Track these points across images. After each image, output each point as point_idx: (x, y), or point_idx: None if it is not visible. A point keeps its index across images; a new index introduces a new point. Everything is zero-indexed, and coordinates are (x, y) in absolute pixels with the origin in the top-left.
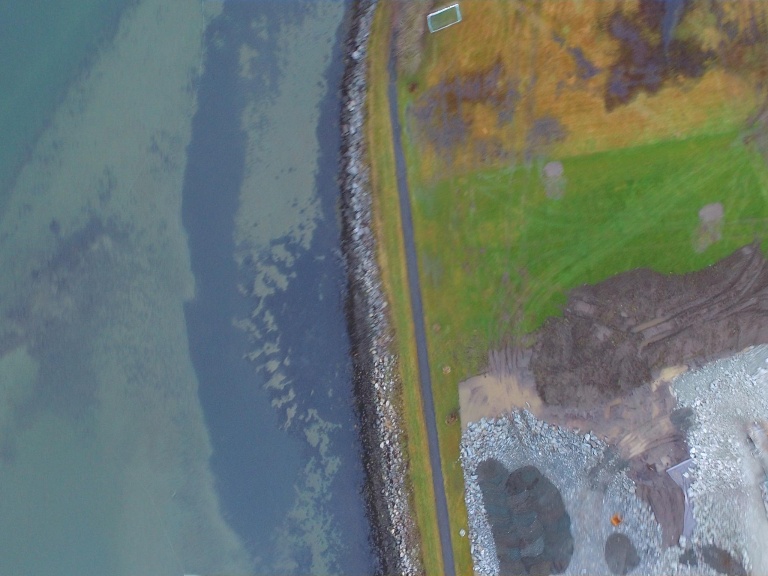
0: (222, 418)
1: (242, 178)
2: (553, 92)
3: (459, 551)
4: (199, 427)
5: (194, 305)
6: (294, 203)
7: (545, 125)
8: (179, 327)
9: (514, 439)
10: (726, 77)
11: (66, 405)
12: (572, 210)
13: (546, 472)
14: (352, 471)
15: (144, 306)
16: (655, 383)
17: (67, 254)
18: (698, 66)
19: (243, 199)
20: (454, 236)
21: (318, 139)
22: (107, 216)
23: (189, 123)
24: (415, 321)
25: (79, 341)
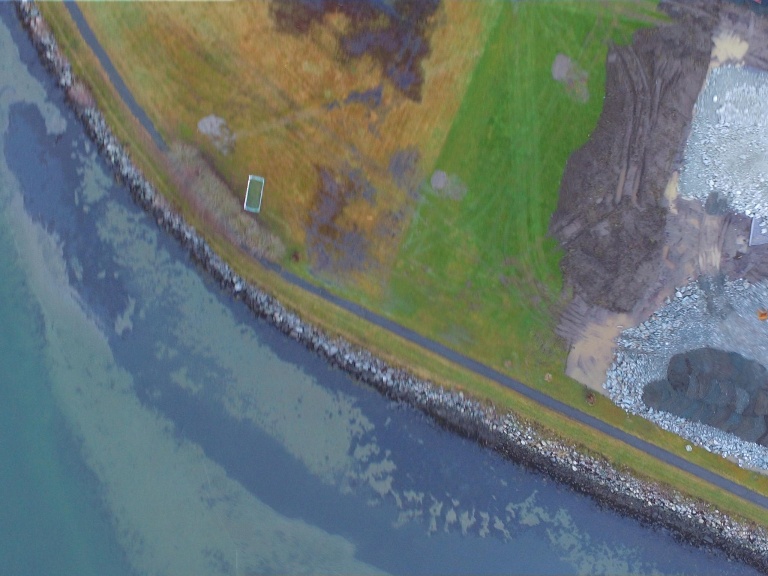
0: None
1: (281, 446)
2: (374, 139)
3: (702, 461)
4: None
5: (361, 550)
6: (329, 415)
7: (397, 164)
8: (372, 573)
9: (641, 358)
10: None
11: None
12: (483, 187)
13: (685, 349)
14: (579, 505)
15: None
16: (671, 208)
17: None
18: None
19: (299, 455)
20: (441, 301)
21: (288, 362)
22: (244, 575)
23: (208, 461)
24: (491, 378)
25: None
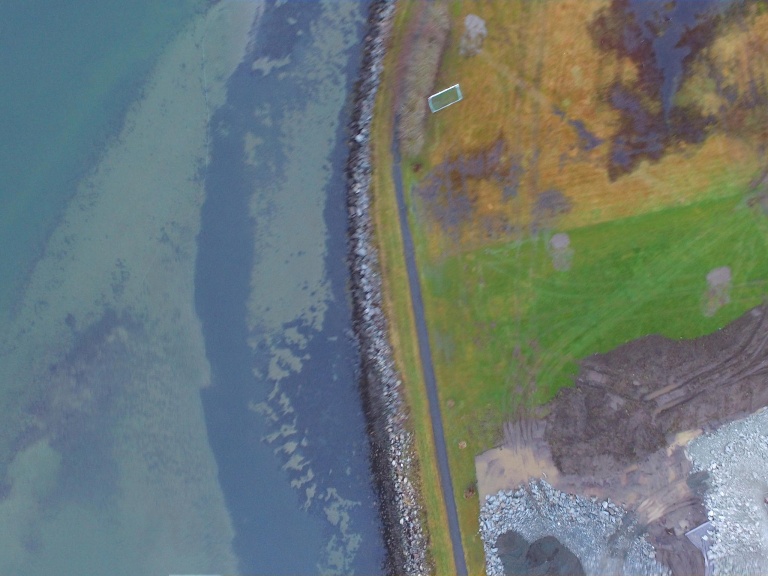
0: (243, 501)
1: (252, 264)
2: (556, 165)
3: None
4: (221, 511)
5: (211, 391)
6: (305, 286)
7: (550, 198)
8: (197, 414)
9: (532, 510)
10: (728, 141)
11: (89, 495)
12: (580, 281)
13: (565, 542)
14: (373, 548)
15: (162, 394)
16: (670, 448)
17: (84, 347)
18: (699, 131)
19: (254, 284)
20: (464, 312)
21: (325, 222)
22: (122, 308)
23: (198, 213)
24: (429, 398)
25: (99, 432)
